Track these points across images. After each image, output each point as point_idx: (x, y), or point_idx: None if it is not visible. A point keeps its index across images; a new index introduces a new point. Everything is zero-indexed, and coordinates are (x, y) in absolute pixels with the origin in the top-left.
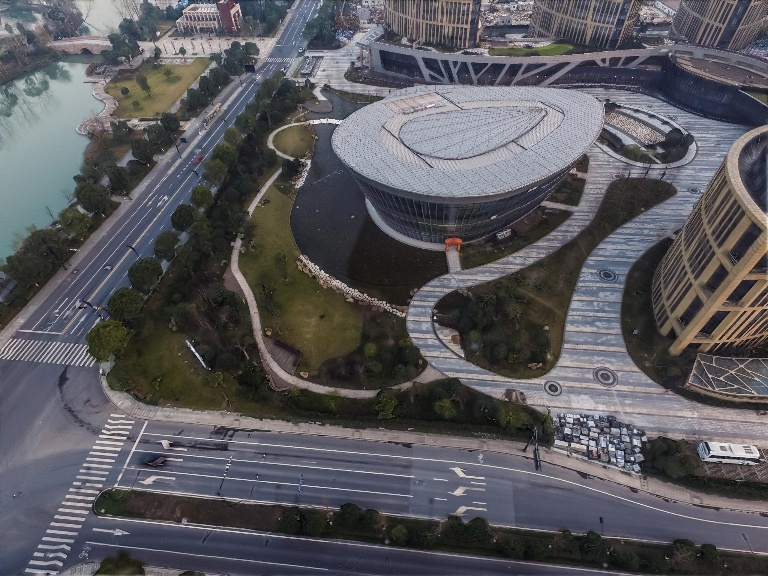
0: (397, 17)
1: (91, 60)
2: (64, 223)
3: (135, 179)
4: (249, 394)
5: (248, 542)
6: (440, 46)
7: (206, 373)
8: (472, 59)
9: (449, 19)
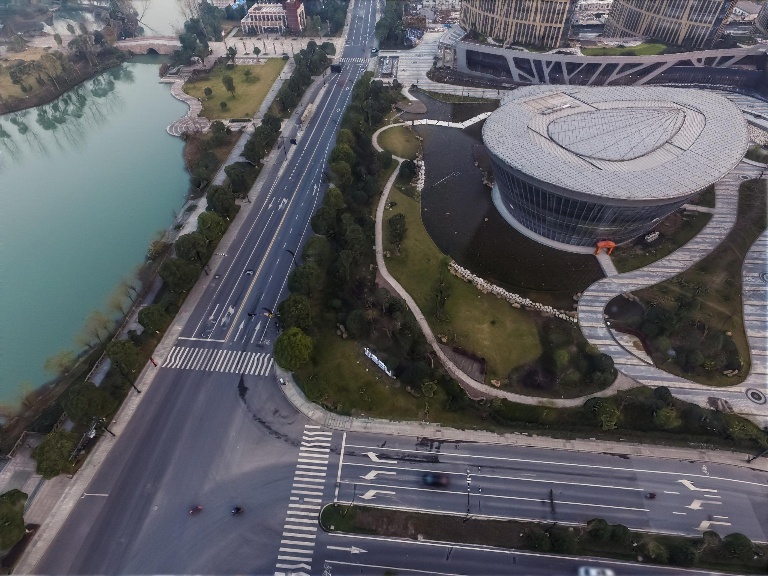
0: (482, 16)
1: (156, 60)
2: (203, 227)
3: None
4: (445, 404)
5: (494, 560)
6: (530, 46)
7: (392, 382)
8: (567, 59)
9: (542, 18)
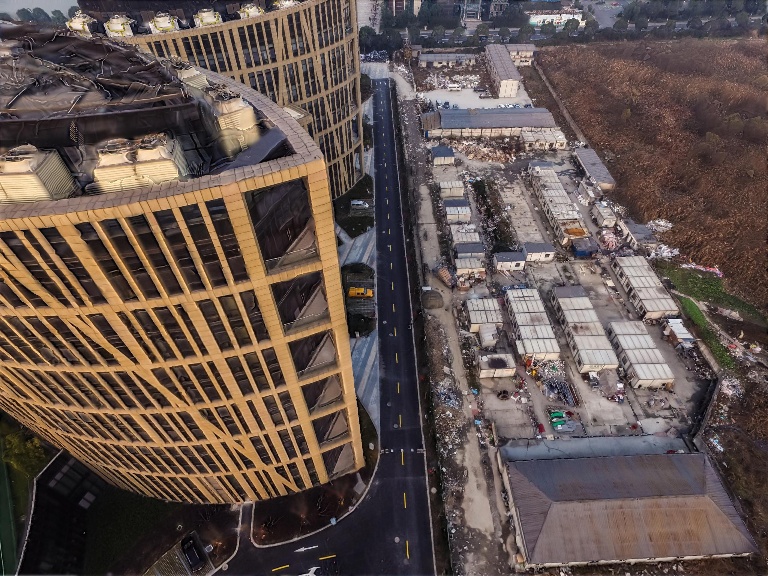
0: None
1: None
2: None
3: None
4: None
5: None
6: None
7: None
8: None
9: None
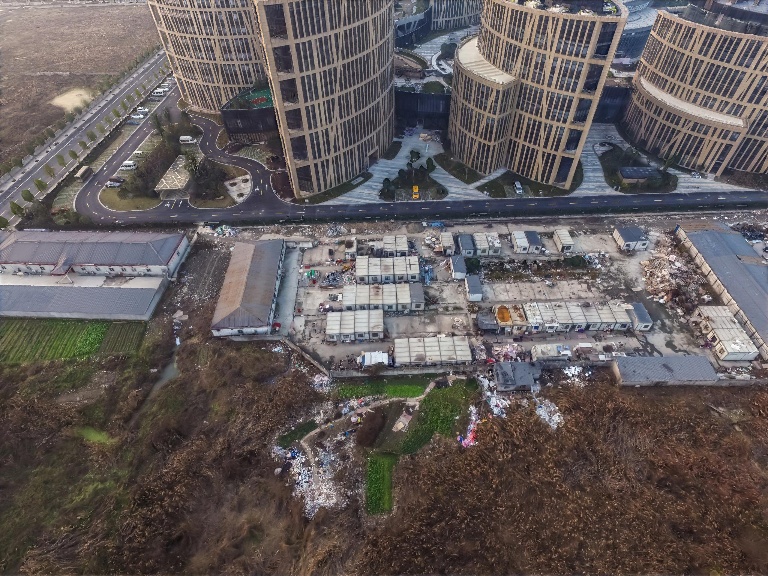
0: None
1: None
2: None
3: None
4: None
5: None
6: None
7: None
8: None
9: None
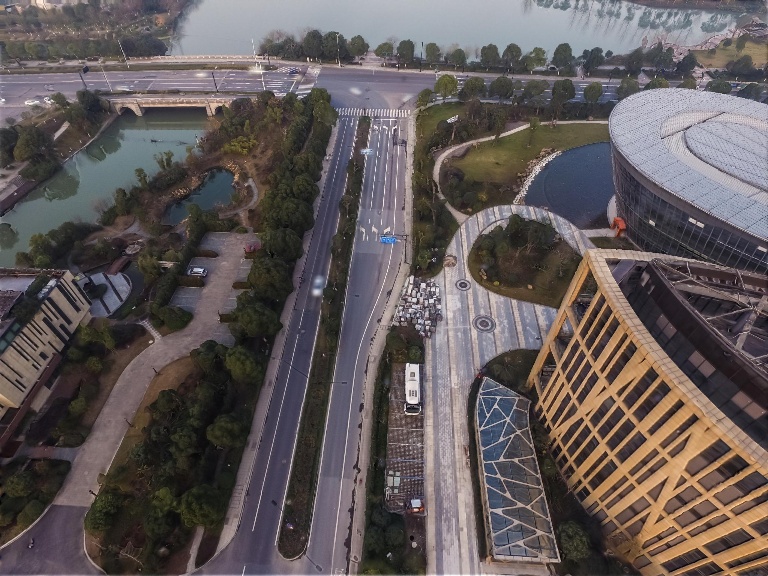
0: None
1: None
2: (531, 54)
3: (608, 75)
4: None
5: (347, 158)
6: None
7: None
8: None
9: None
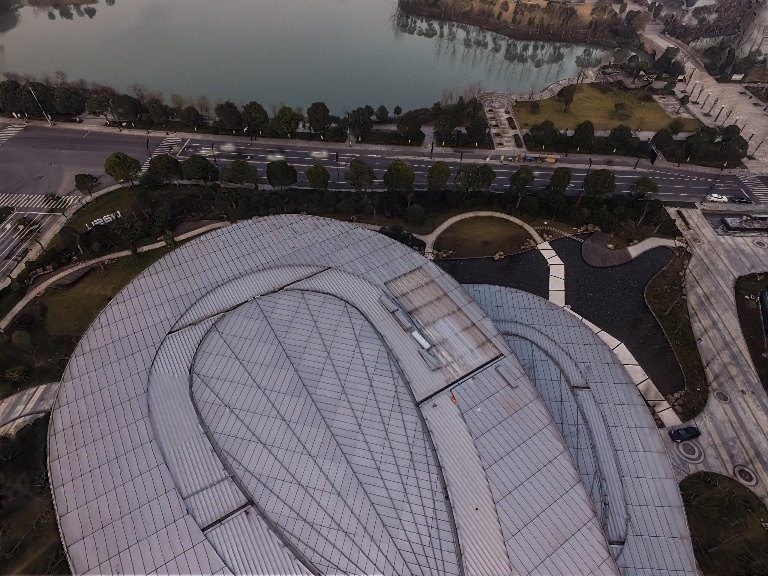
0: None
1: None
2: (279, 115)
3: (384, 140)
4: None
5: None
6: None
7: None
8: None
9: None
